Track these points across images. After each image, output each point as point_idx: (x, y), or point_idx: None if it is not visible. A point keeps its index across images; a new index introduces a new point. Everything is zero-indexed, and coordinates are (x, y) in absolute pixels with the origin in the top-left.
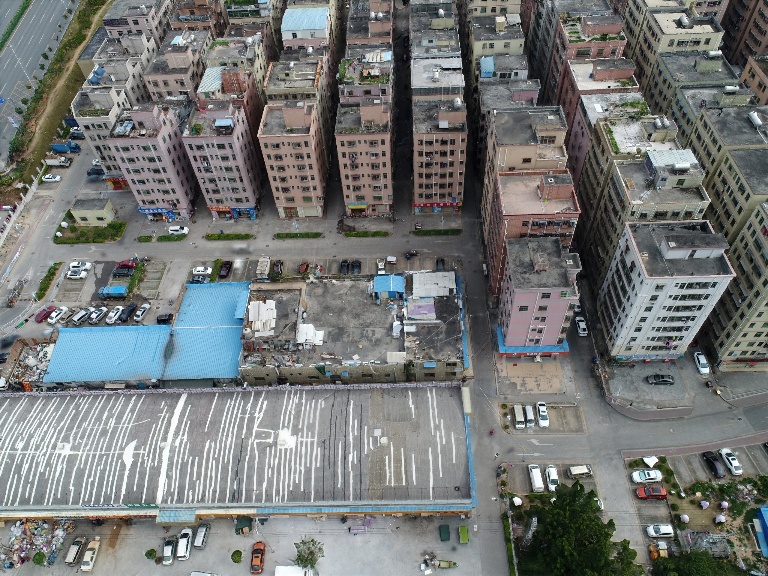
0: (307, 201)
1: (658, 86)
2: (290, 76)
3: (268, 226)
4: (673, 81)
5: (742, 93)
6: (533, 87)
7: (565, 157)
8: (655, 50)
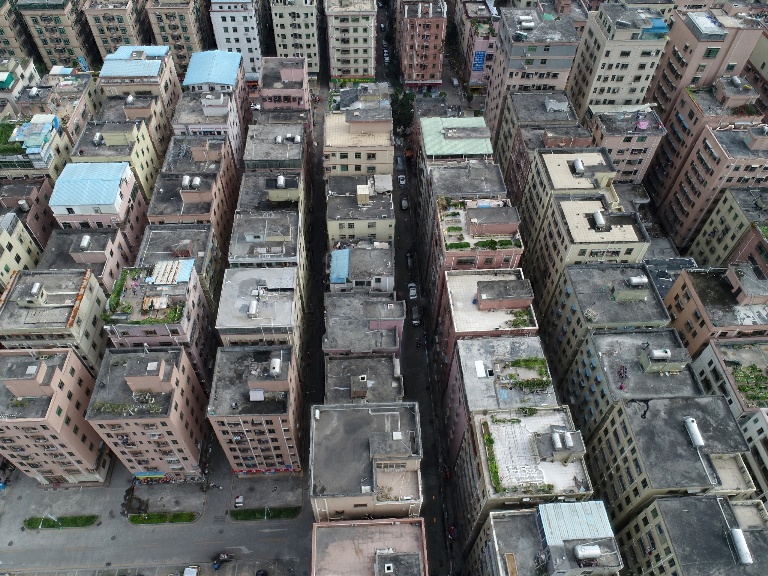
0: (73, 472)
1: (565, 309)
2: (35, 303)
3: (20, 501)
4: (583, 321)
5: (675, 358)
6: (395, 317)
7: (419, 499)
8: (562, 257)
